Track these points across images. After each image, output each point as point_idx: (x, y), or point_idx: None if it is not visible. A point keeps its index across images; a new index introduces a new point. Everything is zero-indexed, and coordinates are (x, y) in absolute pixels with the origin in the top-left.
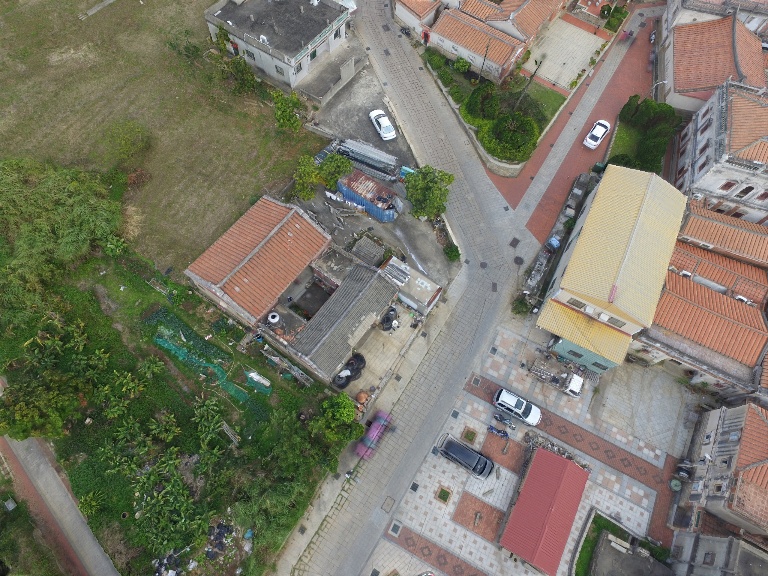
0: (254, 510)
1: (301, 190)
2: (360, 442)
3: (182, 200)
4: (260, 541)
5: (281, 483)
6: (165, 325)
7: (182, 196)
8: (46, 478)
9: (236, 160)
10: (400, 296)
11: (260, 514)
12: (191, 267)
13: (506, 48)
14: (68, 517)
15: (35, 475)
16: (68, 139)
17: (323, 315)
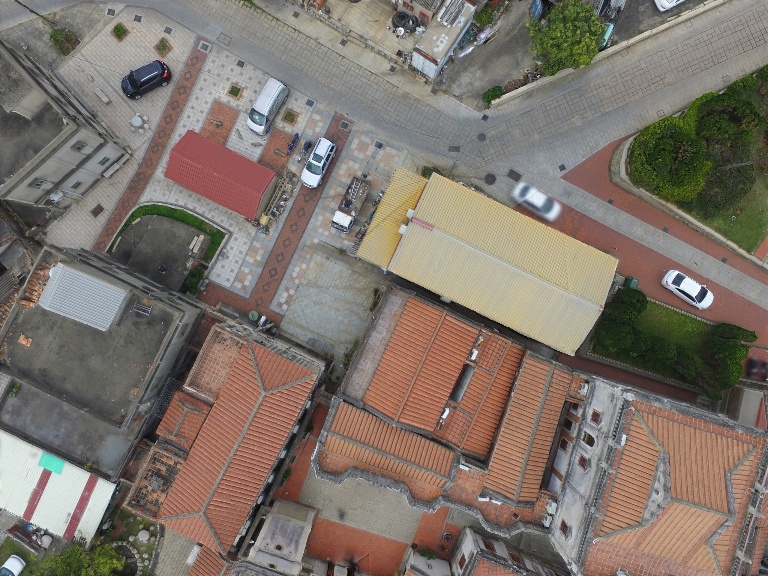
0: None
1: None
2: (278, 7)
3: None
4: None
5: None
6: None
7: None
8: None
9: None
10: None
11: None
12: None
13: None
14: None
15: None
16: None
17: None
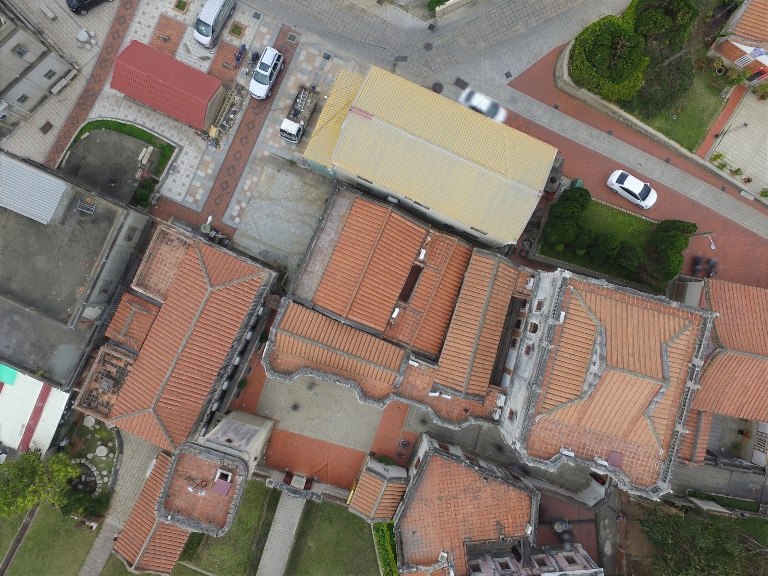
0: None
1: None
2: None
3: None
4: None
5: None
6: None
7: None
8: None
9: None
10: None
11: None
12: None
13: (766, 33)
14: None
15: None
16: None
17: None
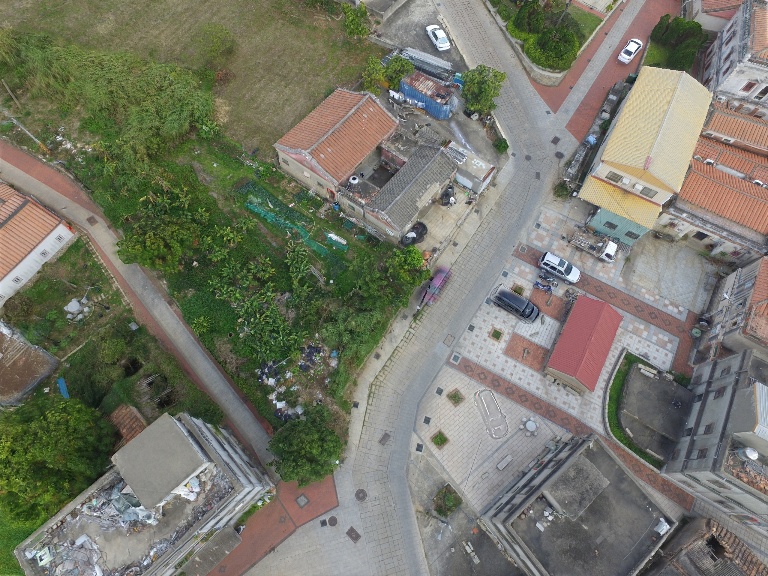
0: (341, 330)
1: (369, 88)
2: (424, 292)
3: (263, 95)
4: (347, 354)
5: (362, 313)
6: (254, 194)
7: (263, 92)
8: (160, 309)
9: (308, 64)
10: (457, 177)
11: (346, 333)
12: (279, 141)
13: None
14: (181, 339)
15: (151, 307)
16: (161, 42)
17: (394, 183)
